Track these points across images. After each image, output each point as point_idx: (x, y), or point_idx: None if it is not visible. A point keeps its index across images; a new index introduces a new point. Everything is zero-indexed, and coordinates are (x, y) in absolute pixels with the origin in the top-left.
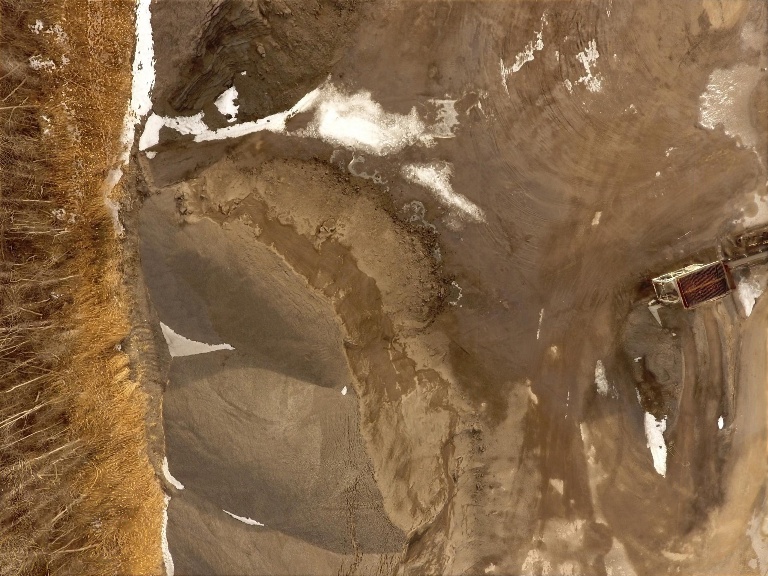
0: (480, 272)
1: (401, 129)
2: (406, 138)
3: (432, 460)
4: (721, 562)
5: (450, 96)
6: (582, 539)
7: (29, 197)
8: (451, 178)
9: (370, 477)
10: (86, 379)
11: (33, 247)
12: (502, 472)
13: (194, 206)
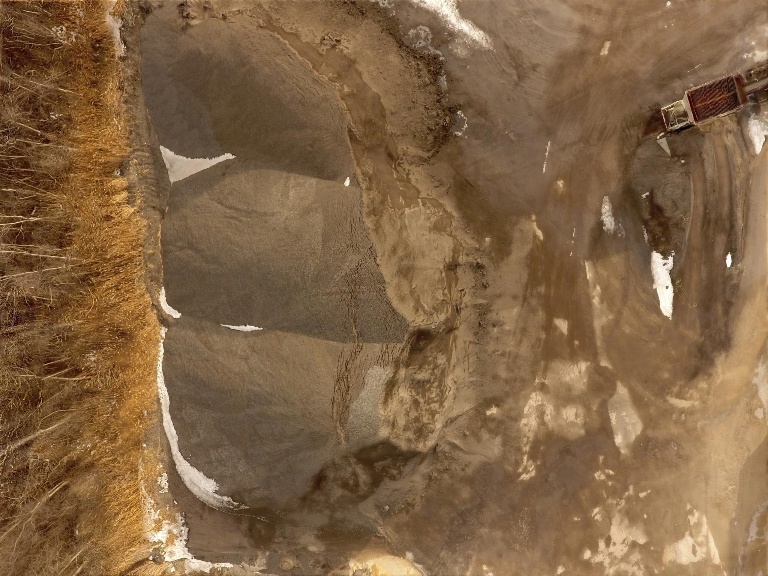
0: (486, 101)
1: None
2: None
3: (435, 271)
4: (727, 410)
5: None
6: (586, 382)
7: (29, 8)
8: (458, 3)
9: (372, 261)
10: (84, 203)
11: (32, 60)
12: (505, 310)
13: (197, 13)
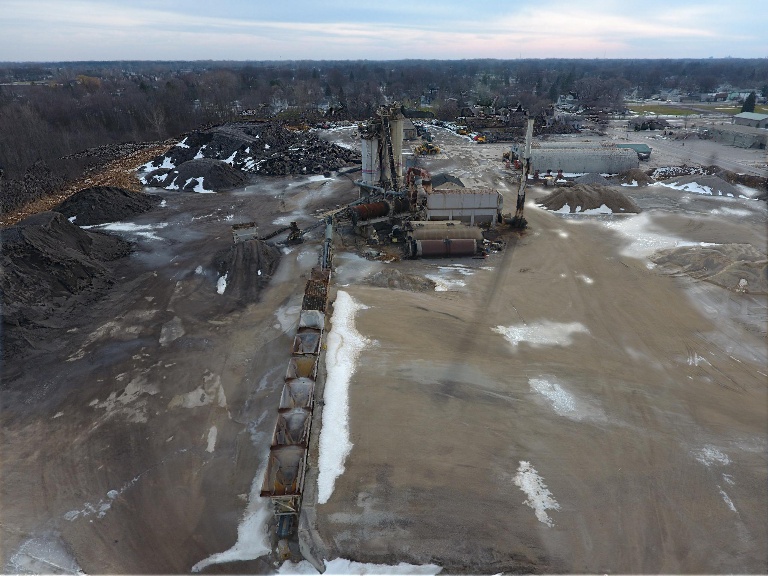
0: None
1: (141, 227)
2: None
3: None
4: (252, 325)
5: (167, 222)
6: (152, 317)
7: None
8: None
9: None
10: None
11: None
12: (116, 295)
13: None
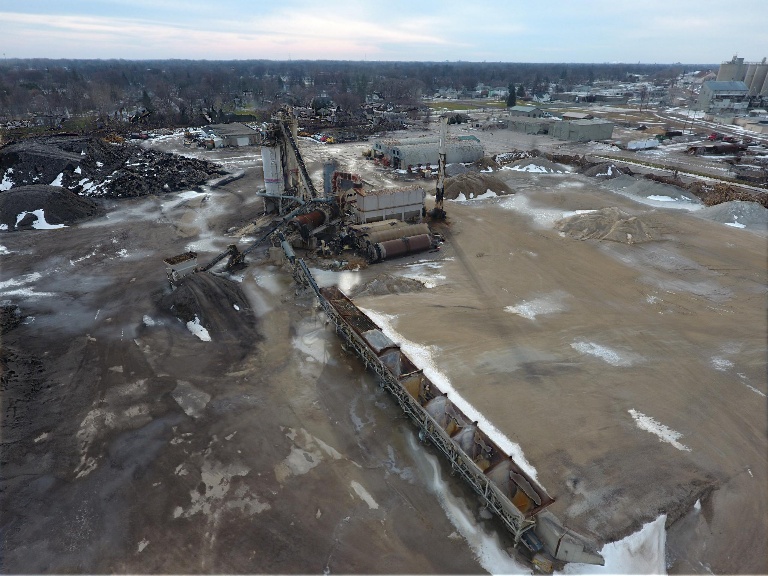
0: (50, 309)
1: None
2: (4, 286)
3: None
4: (282, 365)
5: (37, 272)
6: (146, 389)
7: None
8: (33, 289)
9: None
10: None
11: None
12: (61, 377)
13: None
